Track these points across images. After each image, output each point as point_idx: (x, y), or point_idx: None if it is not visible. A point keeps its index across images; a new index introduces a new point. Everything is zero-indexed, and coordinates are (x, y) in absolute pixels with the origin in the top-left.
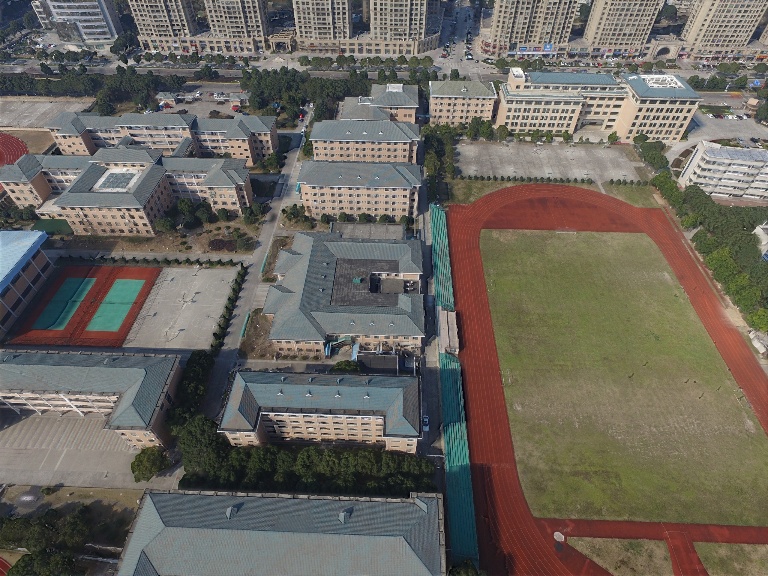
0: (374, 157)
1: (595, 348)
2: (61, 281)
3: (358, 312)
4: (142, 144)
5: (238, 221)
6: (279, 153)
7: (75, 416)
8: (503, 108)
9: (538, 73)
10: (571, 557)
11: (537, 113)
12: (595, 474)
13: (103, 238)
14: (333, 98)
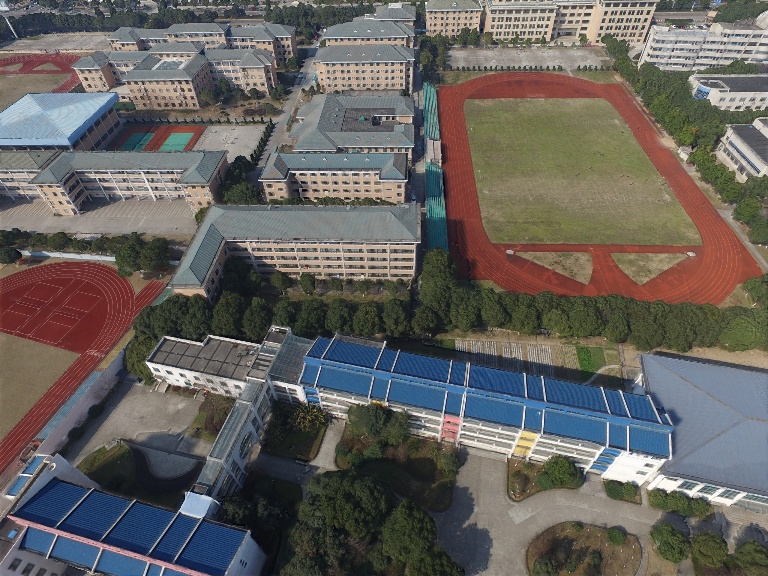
0: None
1: (551, 161)
2: (129, 135)
3: (362, 132)
4: None
5: (266, 99)
6: (298, 60)
7: (150, 201)
8: (488, 18)
9: None
10: (518, 261)
11: (518, 22)
12: (541, 222)
13: (159, 111)
14: None
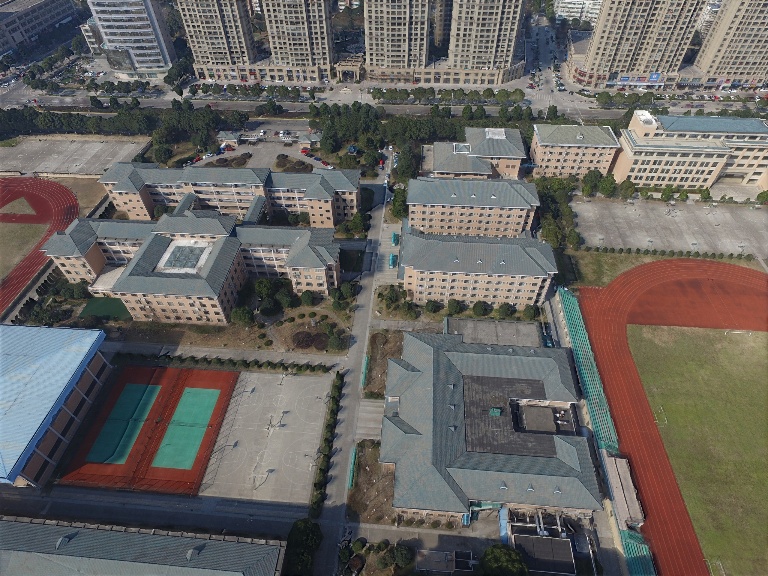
0: (481, 223)
1: None
2: (120, 388)
3: (509, 469)
4: (207, 201)
5: (324, 305)
6: (362, 211)
7: None
8: (628, 160)
9: (670, 118)
10: None
11: (669, 166)
12: None
13: (167, 327)
14: (416, 140)
